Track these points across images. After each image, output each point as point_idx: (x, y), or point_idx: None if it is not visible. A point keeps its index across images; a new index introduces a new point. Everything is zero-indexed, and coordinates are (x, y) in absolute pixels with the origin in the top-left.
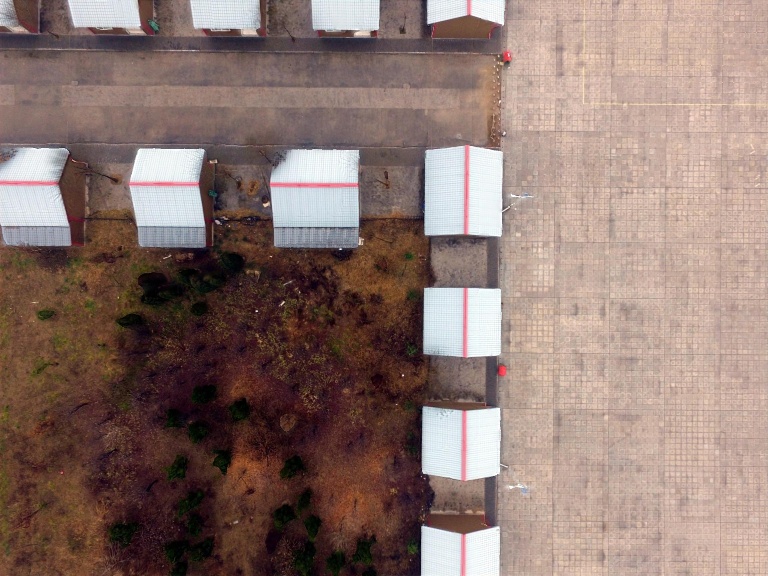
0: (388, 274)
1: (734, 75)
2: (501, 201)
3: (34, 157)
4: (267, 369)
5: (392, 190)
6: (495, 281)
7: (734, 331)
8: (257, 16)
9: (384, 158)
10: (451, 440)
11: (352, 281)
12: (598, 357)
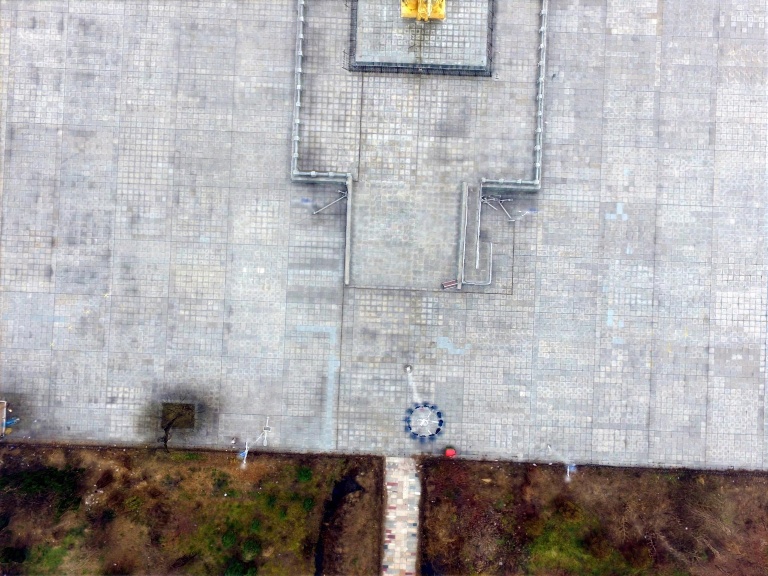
0: None
1: None
2: None
3: None
4: None
5: None
6: None
7: (193, 50)
8: None
9: None
10: None
11: None
12: (54, 72)
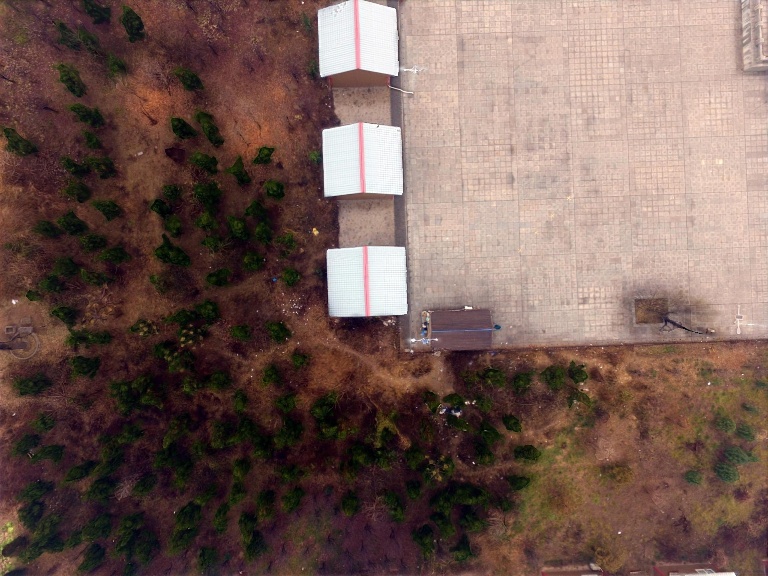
0: None
1: None
2: None
3: None
4: None
5: None
6: None
7: None
8: None
9: None
10: (345, 33)
11: None
12: None
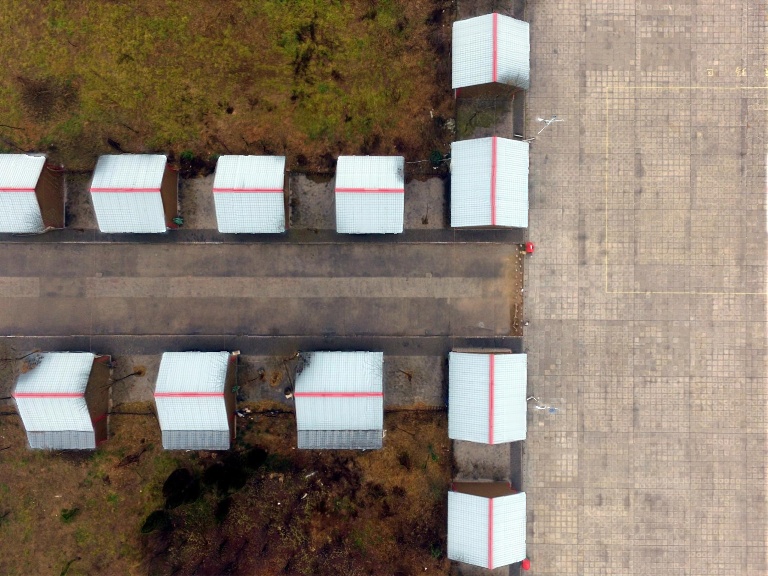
0: (411, 466)
1: (758, 264)
2: (525, 404)
3: (60, 364)
4: None
5: (414, 380)
6: (518, 471)
7: (760, 523)
8: (282, 222)
9: (406, 348)
10: None
11: (375, 473)
12: (623, 548)
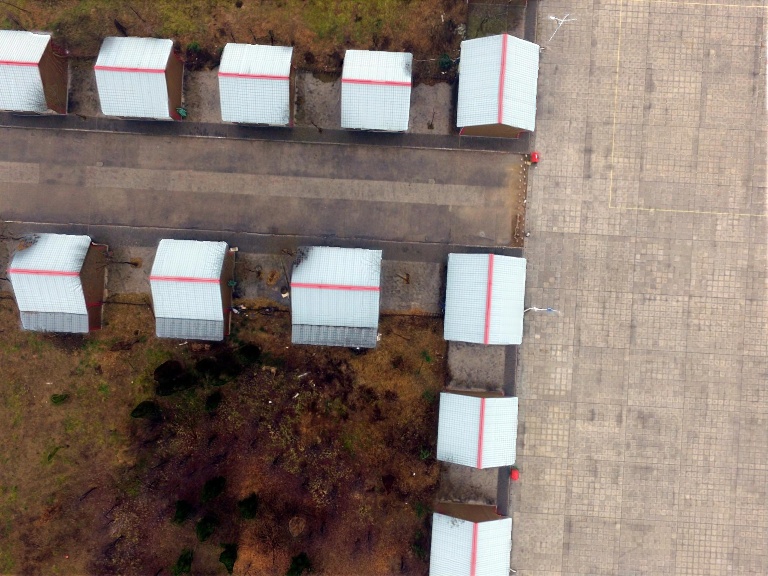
0: (404, 371)
1: (764, 186)
2: (523, 308)
3: (56, 244)
4: (278, 461)
5: (412, 286)
6: (512, 382)
7: (752, 445)
8: (286, 112)
9: (406, 253)
10: (461, 551)
11: (367, 376)
12: (613, 464)
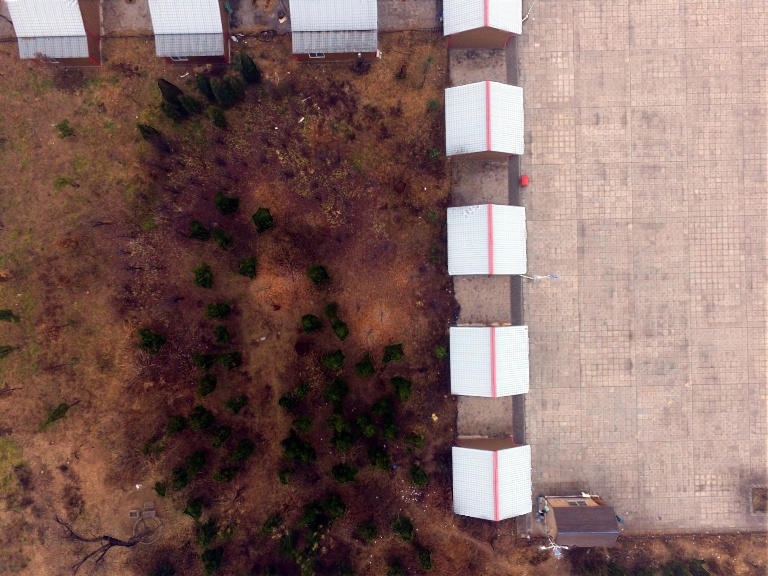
0: (407, 86)
1: None
2: None
3: None
4: (289, 185)
5: (408, 3)
6: None
7: (757, 135)
8: None
9: None
10: (477, 236)
11: (371, 95)
12: (621, 166)
